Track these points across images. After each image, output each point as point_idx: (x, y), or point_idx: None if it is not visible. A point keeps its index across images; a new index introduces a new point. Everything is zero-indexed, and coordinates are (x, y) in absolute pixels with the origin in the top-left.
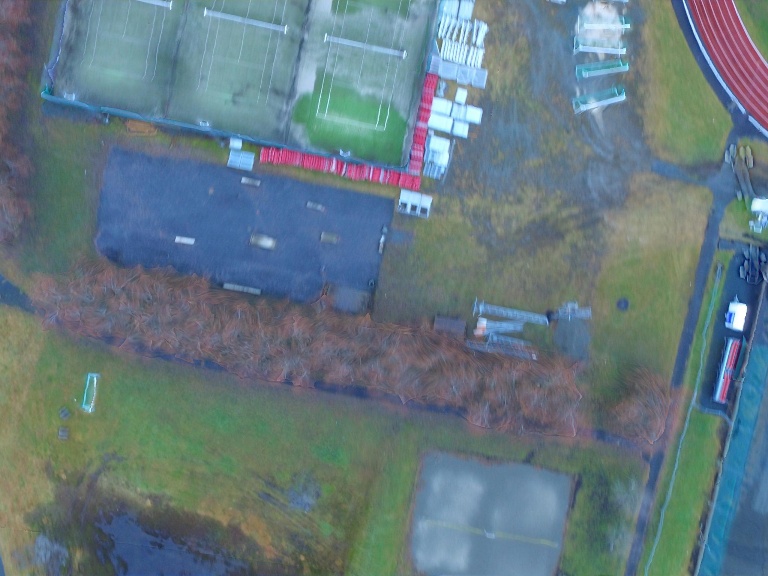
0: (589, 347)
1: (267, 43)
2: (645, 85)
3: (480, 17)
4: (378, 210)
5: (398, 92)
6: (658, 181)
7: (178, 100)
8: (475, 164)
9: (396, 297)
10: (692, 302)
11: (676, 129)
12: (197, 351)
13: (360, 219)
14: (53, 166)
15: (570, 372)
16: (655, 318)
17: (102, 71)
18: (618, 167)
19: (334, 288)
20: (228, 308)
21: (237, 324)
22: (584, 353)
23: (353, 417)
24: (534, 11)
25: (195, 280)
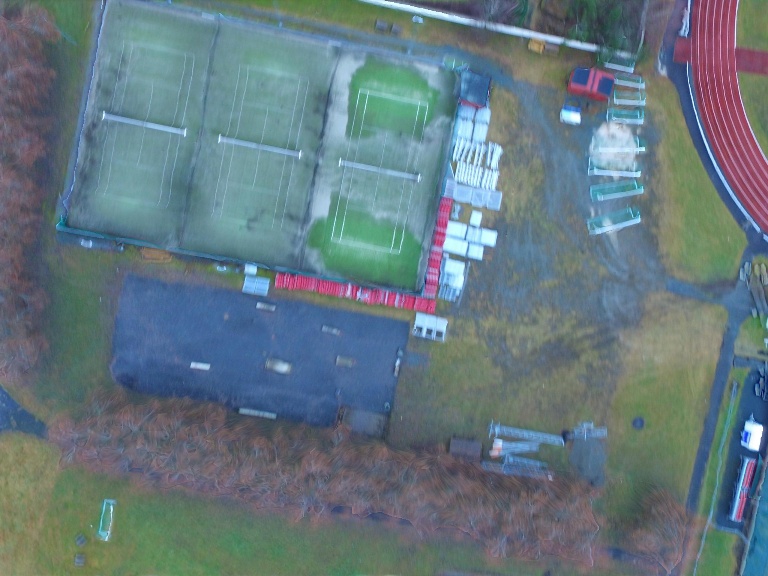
0: (605, 466)
1: (281, 168)
2: (660, 204)
3: (494, 139)
4: (393, 333)
5: (413, 215)
6: (673, 300)
7: (193, 227)
8: (490, 286)
9: (412, 419)
10: (708, 420)
11: (691, 248)
12: (215, 488)
13: (375, 342)
14: (68, 294)
15: (587, 500)
16: (671, 436)
17: (117, 199)
18: (633, 287)
19: (350, 412)
20: (245, 443)
21: (255, 462)
22: (600, 472)
23: (369, 539)
24: (548, 132)
25: (211, 411)
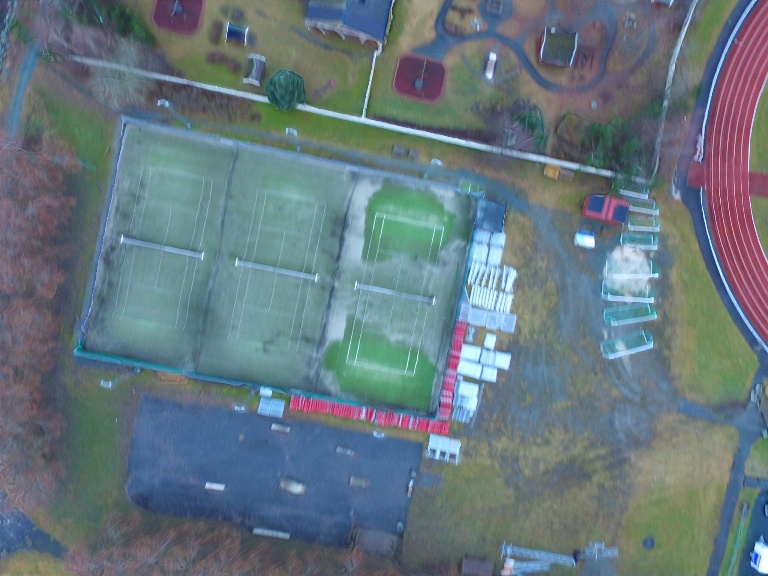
0: None
1: (298, 291)
2: (672, 327)
3: (509, 263)
4: (407, 453)
5: (427, 338)
6: (685, 421)
7: (209, 349)
8: (503, 407)
9: (424, 538)
10: (718, 540)
11: (703, 370)
12: None
13: (389, 462)
14: (84, 415)
15: None
16: (681, 556)
17: (134, 322)
18: (645, 408)
19: (363, 532)
20: (260, 572)
21: None
22: None
23: None
24: (563, 256)
25: (226, 537)
